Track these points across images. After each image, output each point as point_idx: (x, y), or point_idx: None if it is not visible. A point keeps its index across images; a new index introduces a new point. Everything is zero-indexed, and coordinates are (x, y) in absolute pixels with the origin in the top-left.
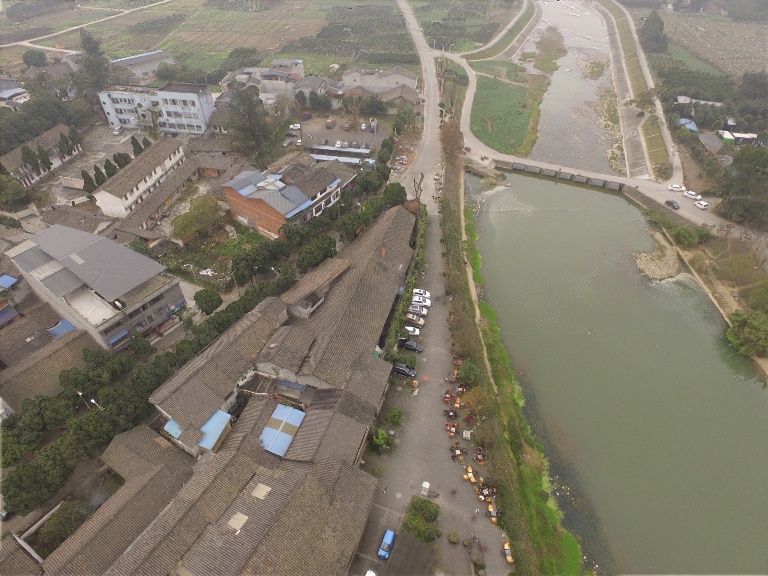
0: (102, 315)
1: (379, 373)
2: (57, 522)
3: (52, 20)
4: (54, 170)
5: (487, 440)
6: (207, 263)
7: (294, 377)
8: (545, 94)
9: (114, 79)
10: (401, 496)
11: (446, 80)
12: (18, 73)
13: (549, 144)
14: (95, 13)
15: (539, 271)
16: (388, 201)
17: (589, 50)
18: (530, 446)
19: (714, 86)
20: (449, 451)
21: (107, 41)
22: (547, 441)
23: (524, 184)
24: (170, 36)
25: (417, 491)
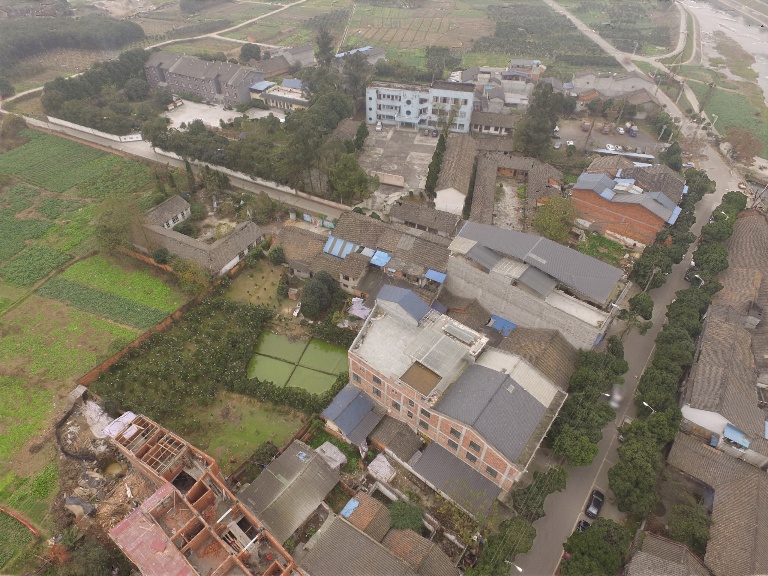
0: (590, 316)
1: None
2: None
3: (222, 13)
4: None
5: None
6: None
7: None
8: (765, 102)
9: None
10: None
11: (664, 85)
12: None
13: None
14: (257, 7)
15: None
16: None
17: None
18: None
19: None
20: None
21: (290, 35)
22: None
23: None
24: (347, 32)
25: None
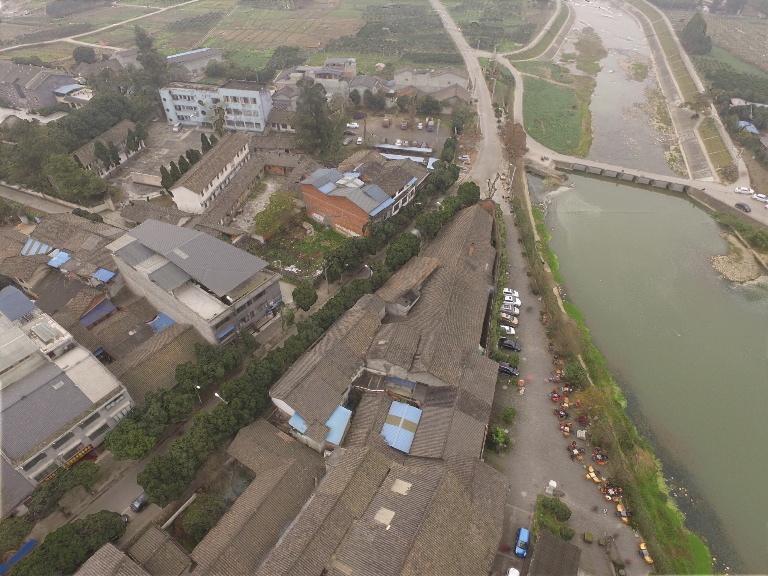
0: (211, 310)
1: (488, 371)
2: (201, 514)
3: (91, 17)
4: (121, 166)
5: (605, 440)
6: (290, 260)
7: (405, 374)
8: (592, 95)
9: (170, 76)
10: (526, 494)
11: None
12: (67, 69)
13: (605, 145)
14: (132, 10)
15: (618, 272)
16: (462, 200)
17: (629, 51)
18: (641, 447)
19: (765, 89)
20: (566, 450)
21: None
22: (656, 442)
23: (585, 185)
24: (210, 34)
25: (541, 490)
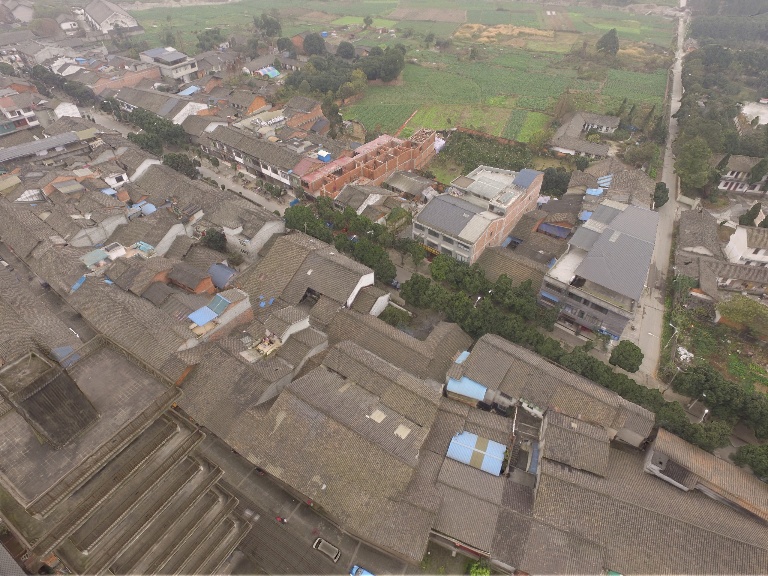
0: (563, 275)
1: (575, 575)
2: (391, 311)
3: None
4: None
5: None
6: (702, 351)
7: None
8: None
9: None
10: None
11: None
12: None
13: None
14: None
15: None
16: None
17: None
18: None
19: None
20: None
21: None
22: None
23: None
24: None
25: None
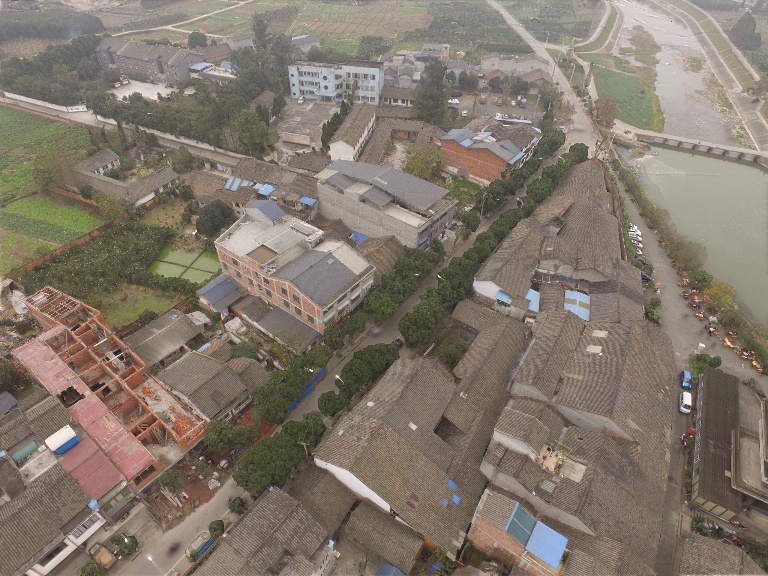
0: (414, 221)
1: (634, 273)
2: None
3: (180, 9)
4: None
5: (735, 321)
6: None
7: (571, 272)
8: (655, 83)
9: None
10: (680, 354)
11: None
12: None
13: (677, 123)
14: (215, 3)
15: (711, 218)
16: None
17: (681, 47)
18: (757, 334)
19: None
20: (703, 329)
21: (240, 28)
22: (767, 332)
23: (664, 155)
24: (294, 25)
25: (691, 352)
